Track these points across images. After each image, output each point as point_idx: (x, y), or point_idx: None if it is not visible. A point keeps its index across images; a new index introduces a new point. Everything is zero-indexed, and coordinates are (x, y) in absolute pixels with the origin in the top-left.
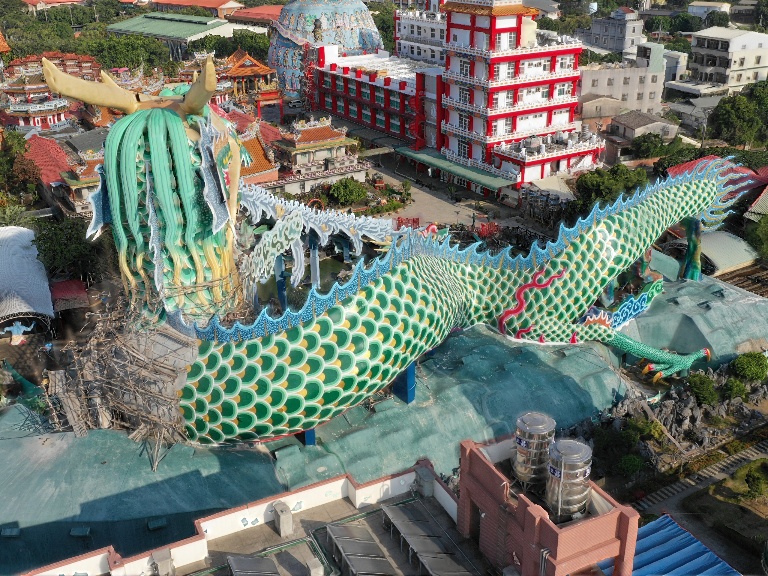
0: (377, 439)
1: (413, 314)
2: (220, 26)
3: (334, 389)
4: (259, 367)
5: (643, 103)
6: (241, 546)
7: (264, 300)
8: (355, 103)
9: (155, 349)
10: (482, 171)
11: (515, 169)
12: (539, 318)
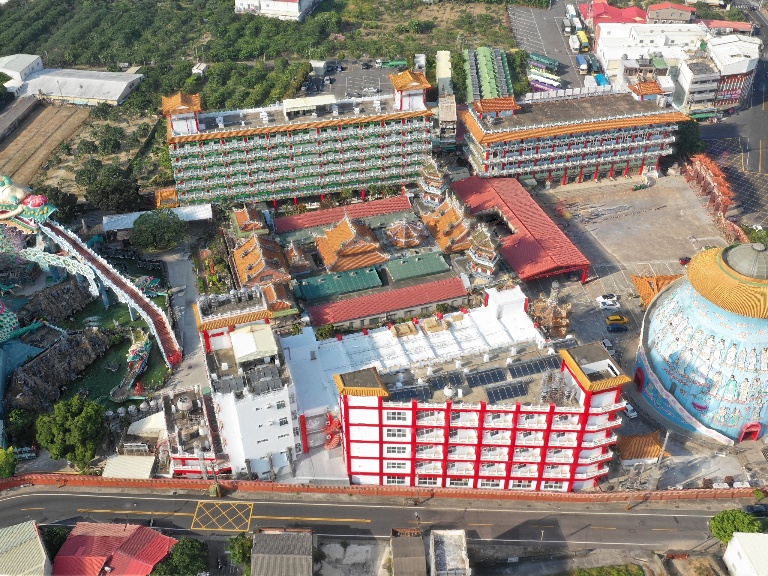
0: None
1: None
2: None
3: None
4: None
5: None
6: None
7: None
8: None
9: None
10: None
11: None
12: None
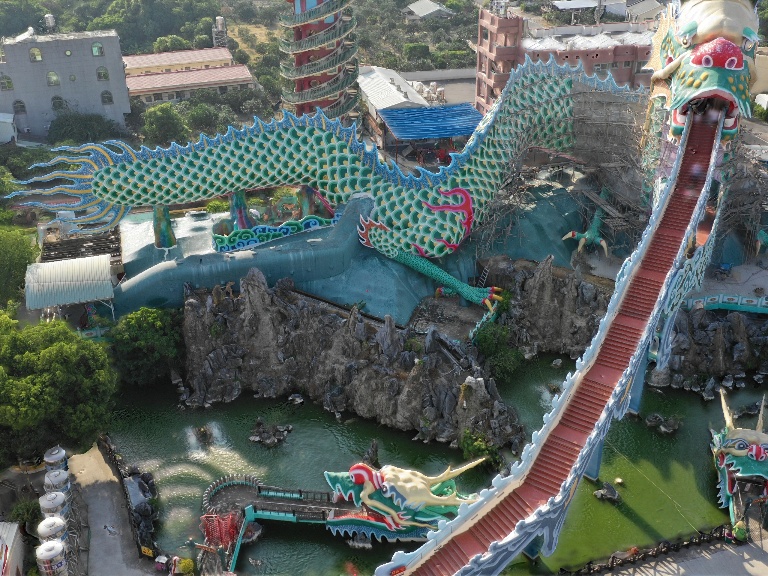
0: None
1: None
2: None
3: None
4: None
5: None
6: None
7: (677, 465)
8: None
9: None
10: None
11: None
12: None
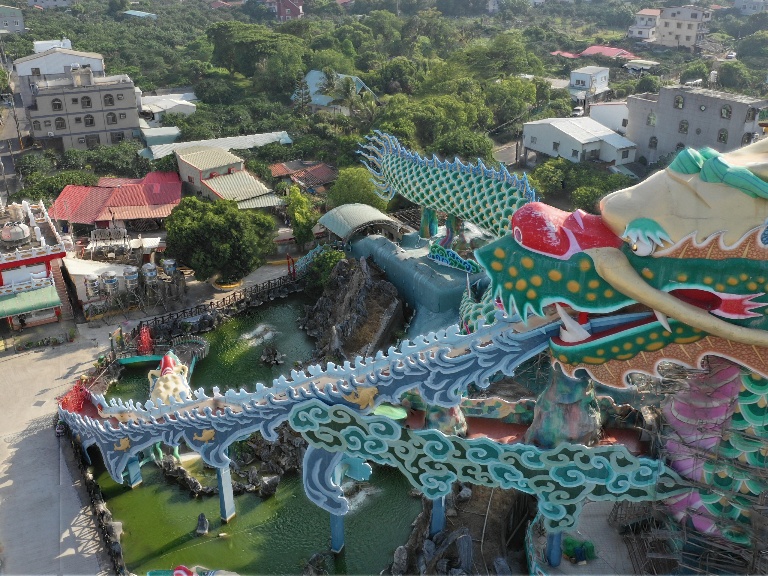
0: None
1: None
2: None
3: None
4: None
5: None
6: None
7: None
8: None
9: None
10: None
11: (33, 272)
12: None
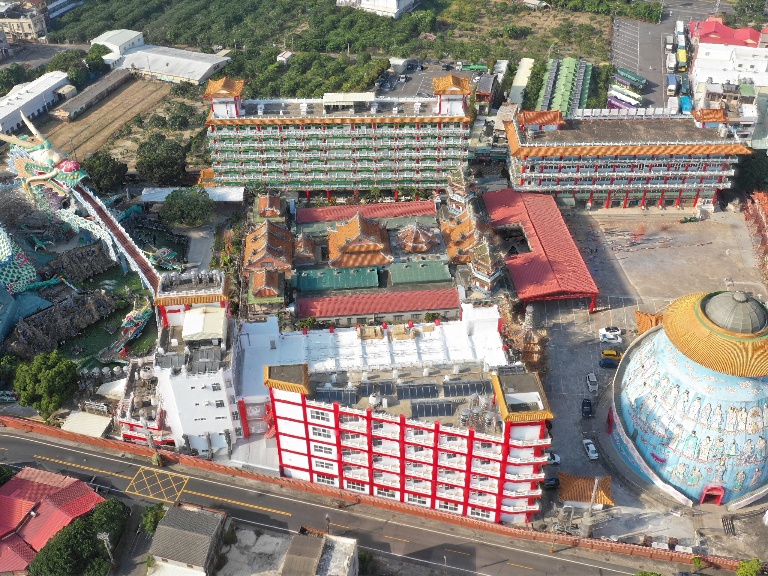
0: None
1: None
2: None
3: None
4: None
5: None
6: None
7: None
8: None
9: None
10: None
11: None
12: None
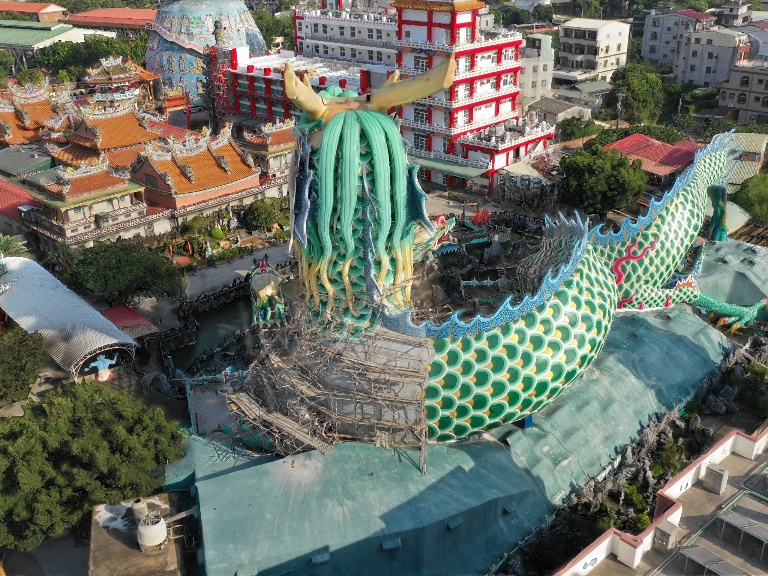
0: (575, 414)
1: (611, 290)
2: (67, 31)
3: (573, 368)
4: (505, 356)
5: (537, 91)
6: (695, 509)
7: None
8: (280, 104)
9: (381, 354)
10: (448, 162)
11: (484, 157)
12: (638, 287)
